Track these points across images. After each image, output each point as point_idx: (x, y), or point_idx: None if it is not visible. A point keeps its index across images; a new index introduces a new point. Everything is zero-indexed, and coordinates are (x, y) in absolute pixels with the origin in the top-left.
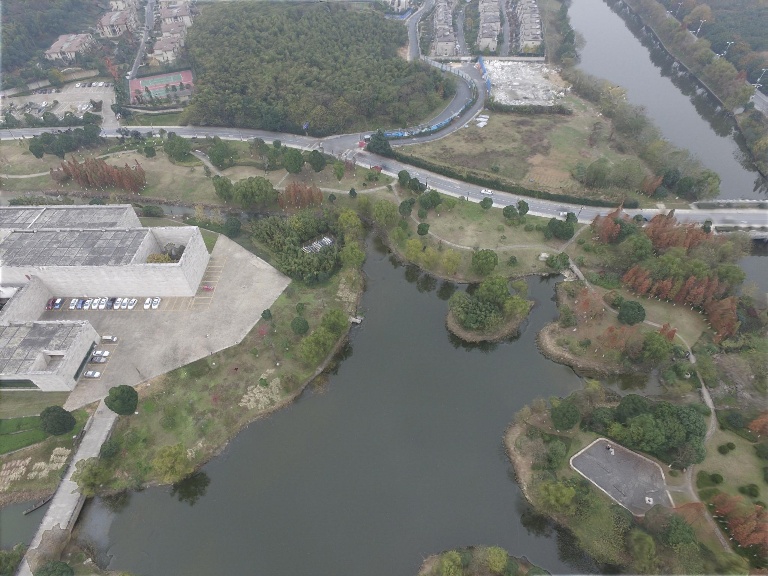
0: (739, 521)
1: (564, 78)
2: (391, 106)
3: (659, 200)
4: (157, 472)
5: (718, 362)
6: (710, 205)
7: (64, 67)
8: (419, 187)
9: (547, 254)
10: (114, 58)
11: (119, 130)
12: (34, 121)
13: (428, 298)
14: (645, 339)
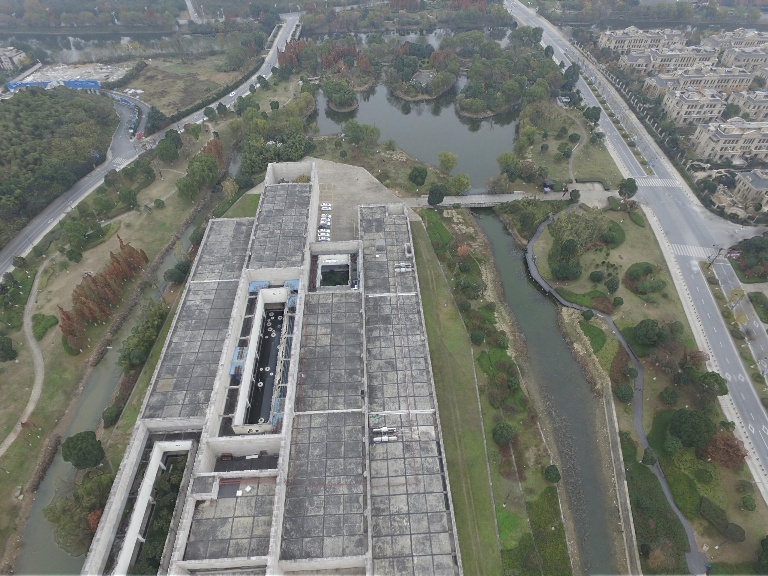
0: None
1: (83, 63)
2: (104, 107)
3: (260, 55)
4: (453, 162)
5: None
6: (270, 45)
7: None
8: (225, 107)
9: (300, 81)
10: None
11: None
12: None
13: None
14: (368, 57)
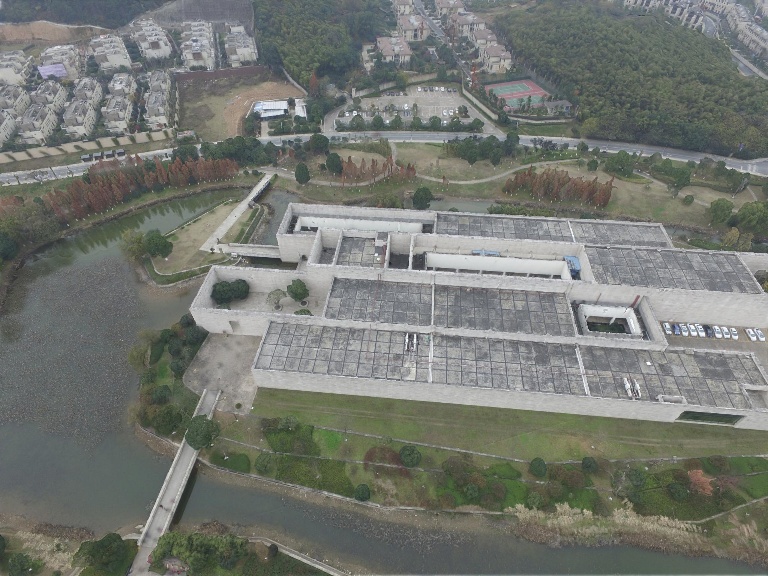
0: None
1: None
2: None
3: None
4: None
5: None
6: None
7: (401, 70)
8: None
9: None
10: (446, 63)
11: (535, 140)
12: (420, 124)
13: None
14: None
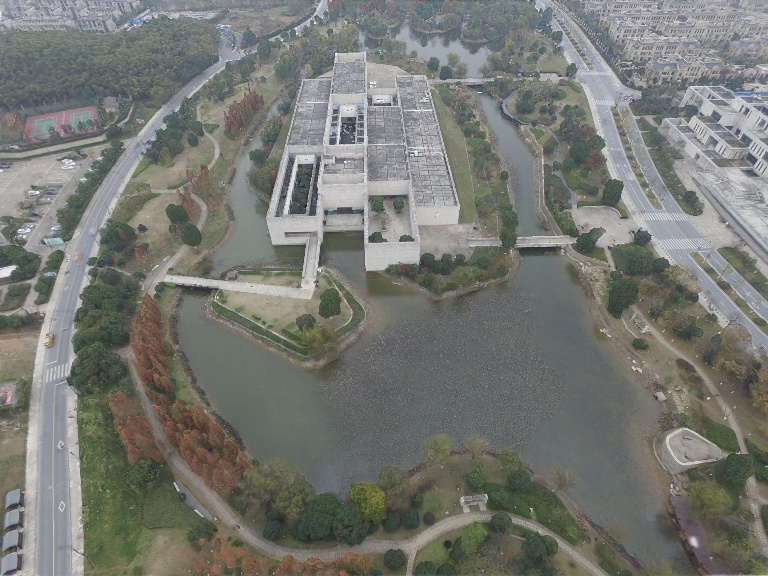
0: None
1: (179, 10)
2: (213, 28)
3: None
4: None
5: None
6: (318, 0)
7: None
8: None
9: None
10: None
11: None
12: None
13: None
14: None
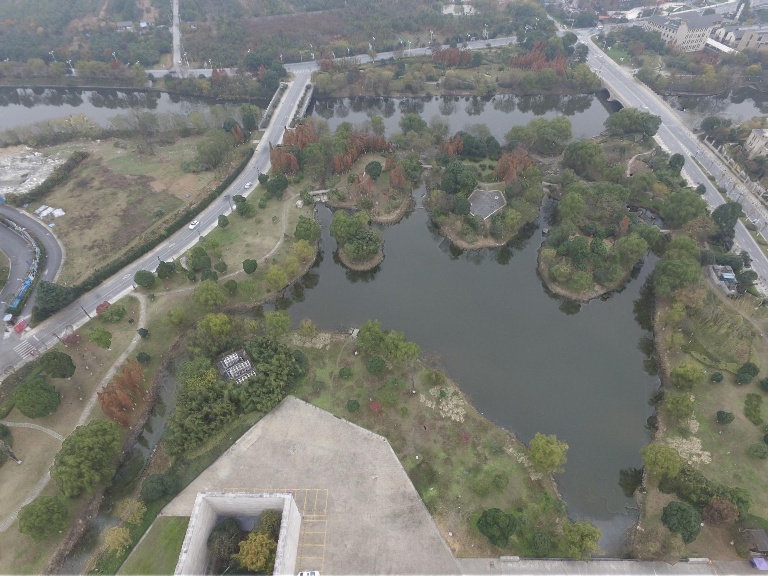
0: (508, 167)
1: (3, 146)
2: None
3: (249, 140)
4: None
5: (402, 158)
6: (265, 123)
7: None
8: (172, 266)
9: (299, 201)
10: None
11: None
12: None
13: (310, 297)
14: (403, 166)
